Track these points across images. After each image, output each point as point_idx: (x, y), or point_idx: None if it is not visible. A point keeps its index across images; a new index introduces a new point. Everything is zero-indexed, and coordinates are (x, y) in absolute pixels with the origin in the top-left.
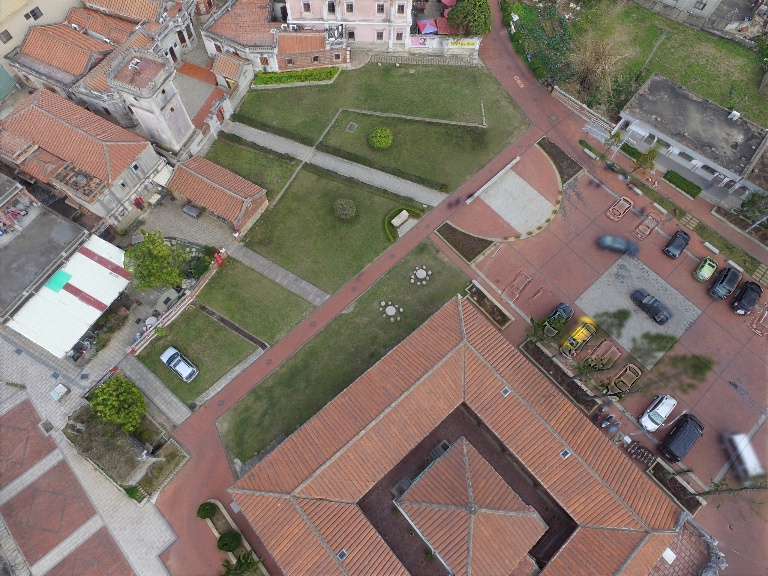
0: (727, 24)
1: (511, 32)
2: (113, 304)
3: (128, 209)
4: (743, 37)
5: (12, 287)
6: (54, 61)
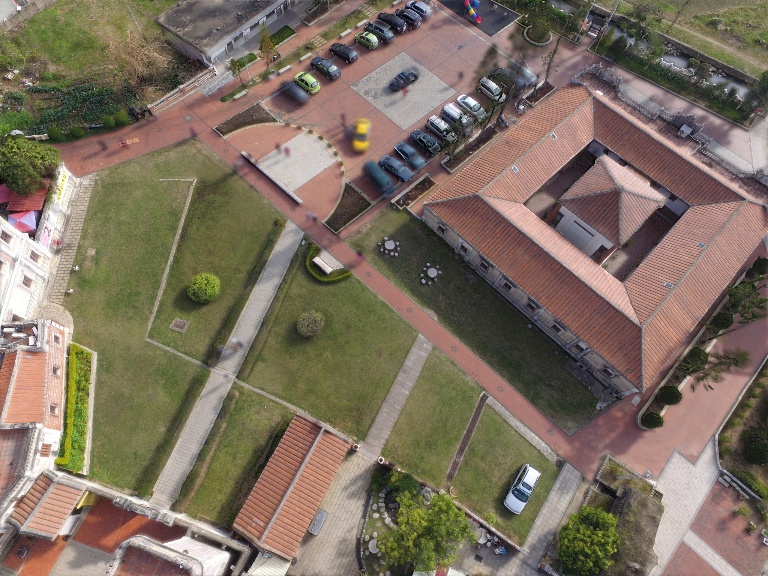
0: None
1: (44, 139)
2: None
3: None
4: None
5: None
6: None
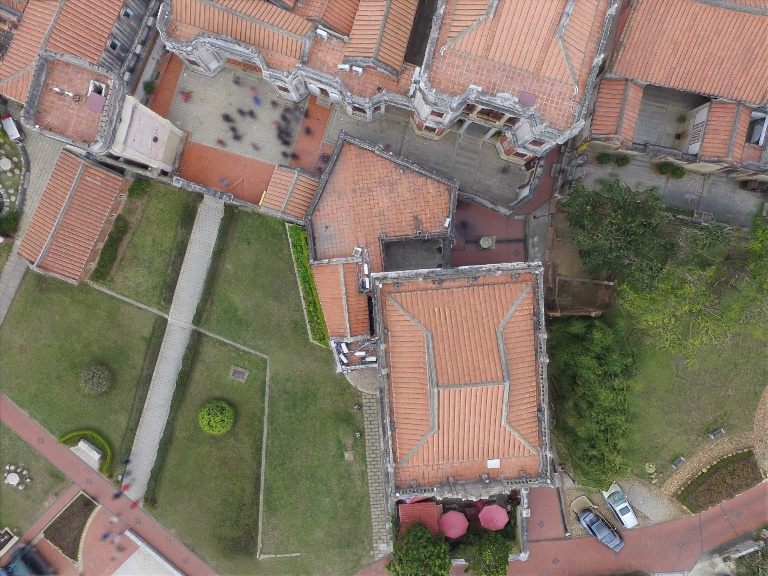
0: None
1: None
2: None
3: None
4: None
5: None
6: None
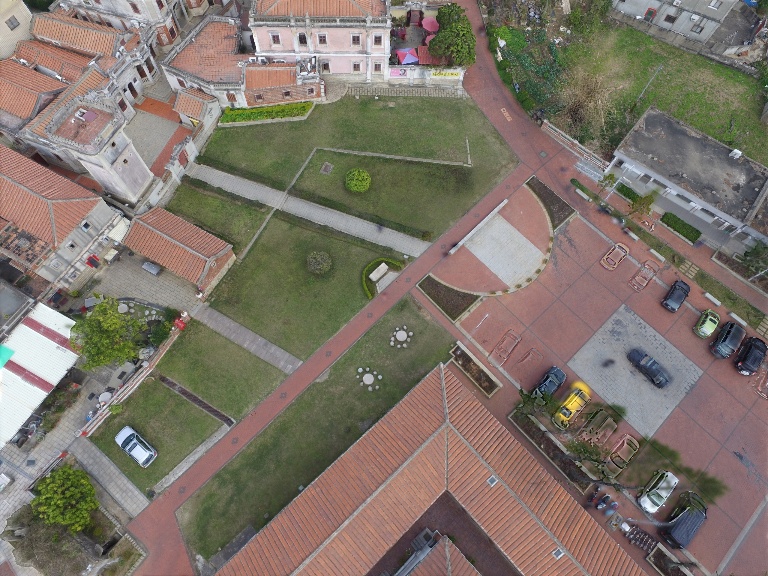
0: (726, 49)
1: (498, 59)
2: (61, 382)
3: (80, 269)
4: (743, 63)
5: None
6: None
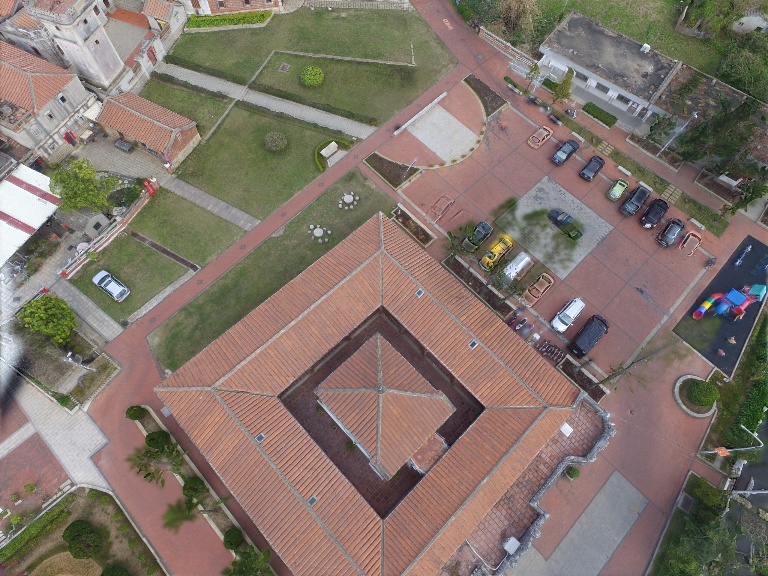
0: None
1: None
2: (42, 229)
3: (58, 143)
4: None
5: None
6: None
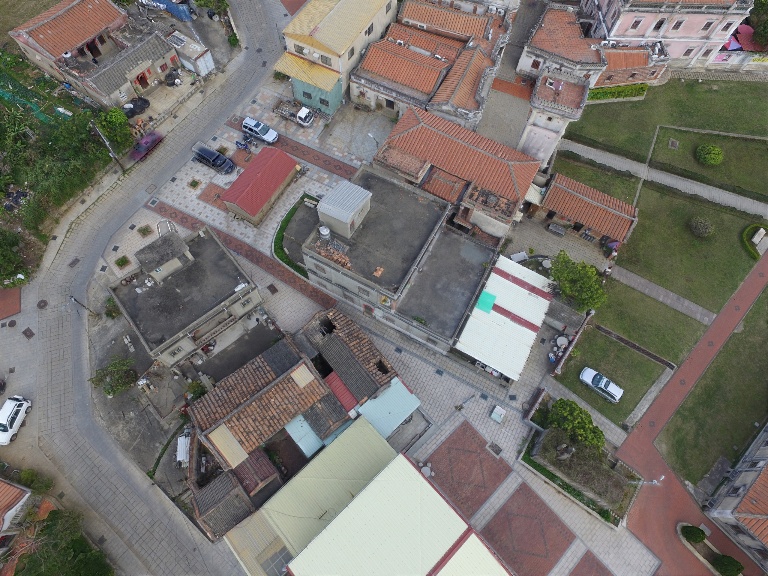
0: None
1: None
2: None
3: None
4: None
5: (446, 308)
6: (399, 78)
